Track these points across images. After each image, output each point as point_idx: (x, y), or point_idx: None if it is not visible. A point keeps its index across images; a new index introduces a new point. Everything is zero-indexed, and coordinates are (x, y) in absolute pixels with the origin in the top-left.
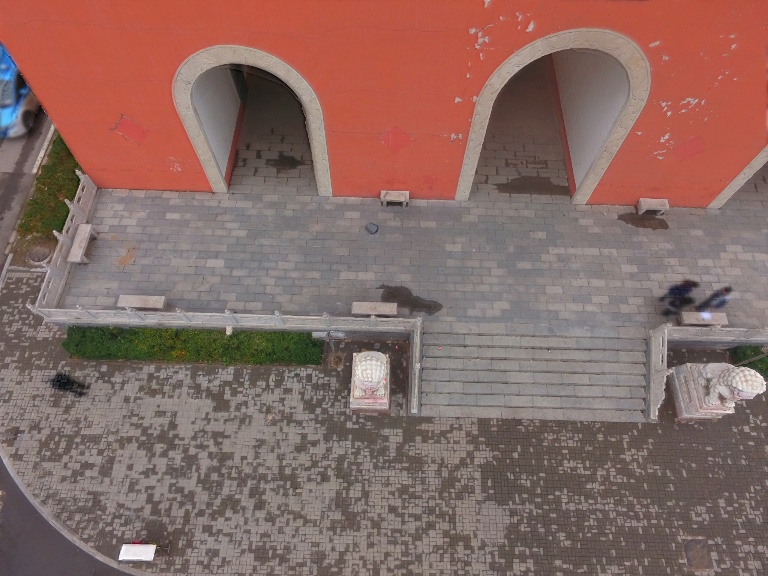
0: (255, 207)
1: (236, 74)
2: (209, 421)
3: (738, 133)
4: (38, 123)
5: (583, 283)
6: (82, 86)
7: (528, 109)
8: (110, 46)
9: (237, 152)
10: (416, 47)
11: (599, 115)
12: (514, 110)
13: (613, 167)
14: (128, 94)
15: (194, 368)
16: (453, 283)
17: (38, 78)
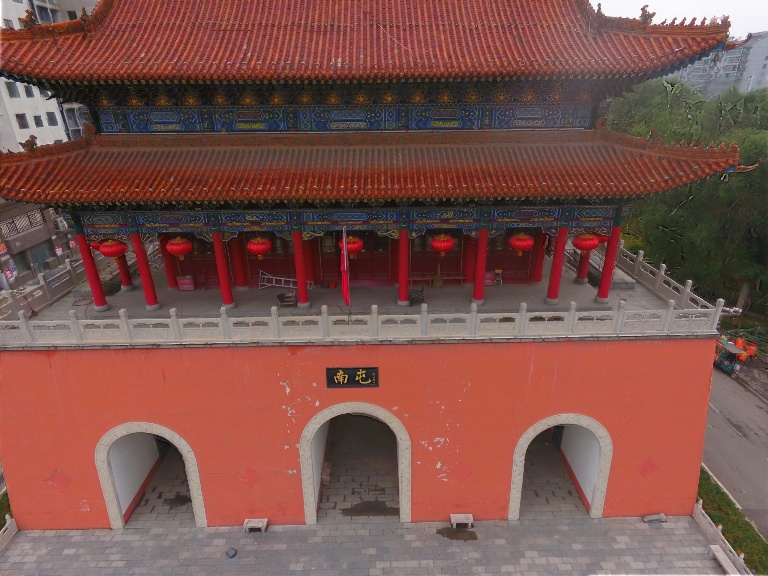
0: (141, 540)
1: None
2: None
3: (487, 459)
4: (0, 480)
5: None
6: (36, 451)
7: (376, 449)
8: (62, 426)
9: (144, 494)
10: (252, 417)
11: None
12: (365, 451)
13: (416, 489)
14: (65, 455)
15: None
16: None
17: (8, 448)
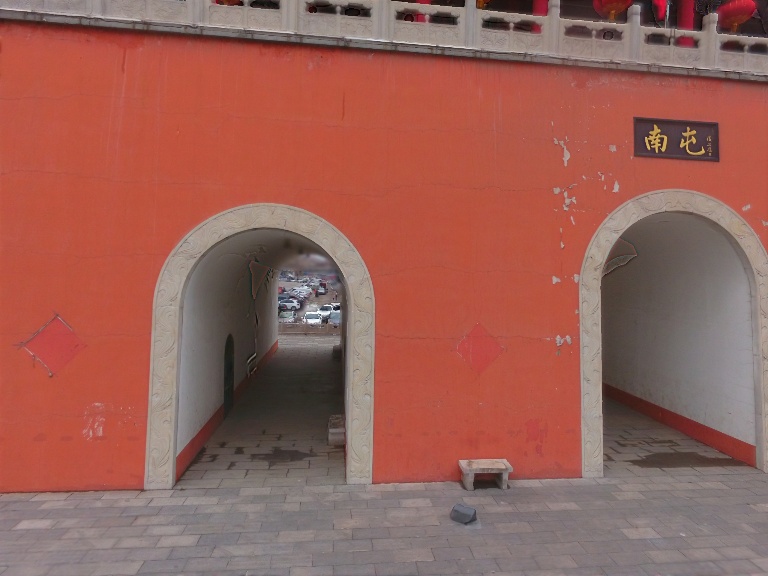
0: (223, 503)
1: (228, 368)
2: None
3: None
4: None
5: None
6: (22, 266)
7: None
8: (104, 207)
9: (203, 449)
10: (497, 209)
11: (715, 339)
12: None
13: None
14: (89, 279)
15: None
16: None
17: None
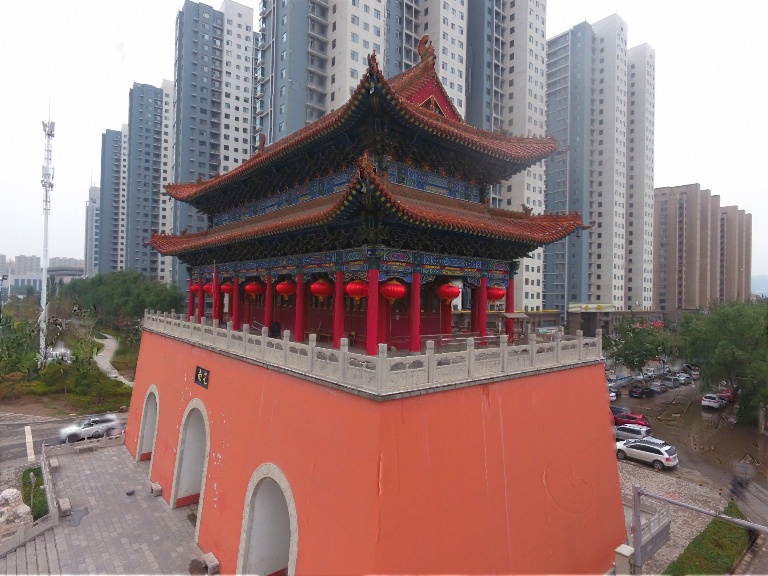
0: None
1: None
2: None
3: None
4: None
5: (117, 564)
6: None
7: None
8: None
9: None
10: None
11: None
12: None
13: None
14: None
15: None
16: (98, 524)
17: None
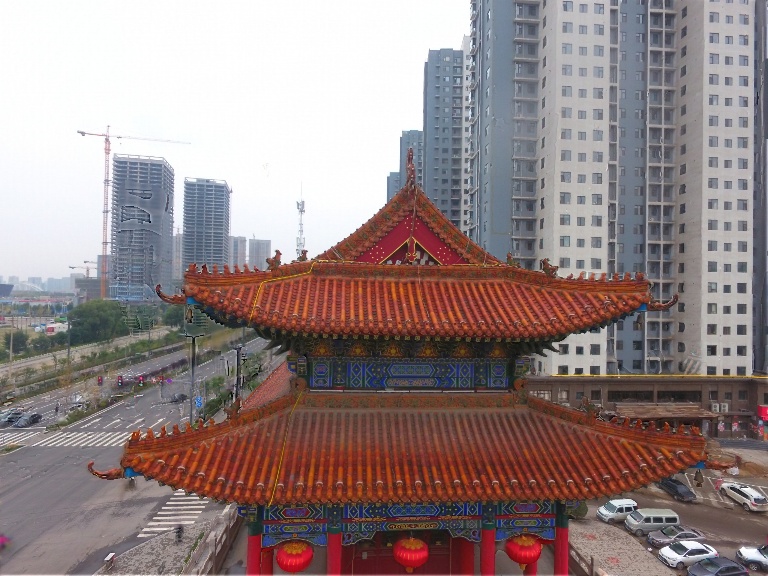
0: None
1: None
2: (153, 575)
3: None
4: None
5: None
6: None
7: None
8: None
9: None
10: None
11: None
12: None
13: None
14: None
15: (181, 567)
16: None
17: None
